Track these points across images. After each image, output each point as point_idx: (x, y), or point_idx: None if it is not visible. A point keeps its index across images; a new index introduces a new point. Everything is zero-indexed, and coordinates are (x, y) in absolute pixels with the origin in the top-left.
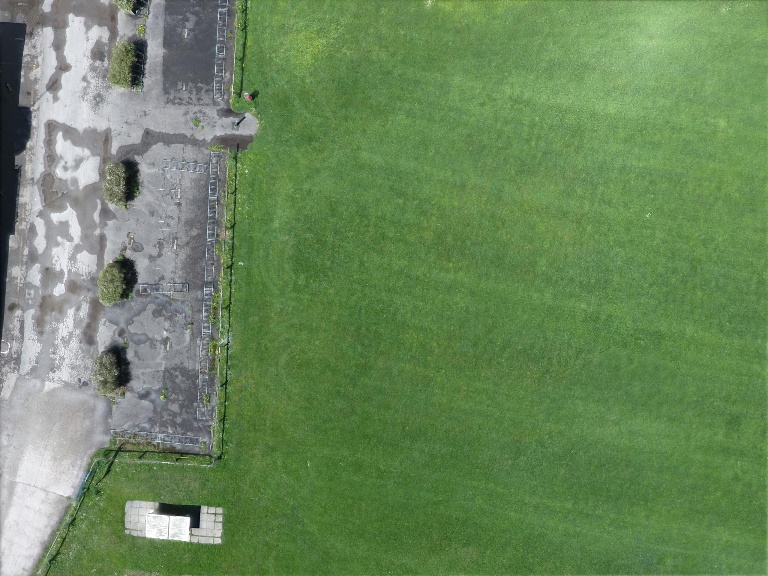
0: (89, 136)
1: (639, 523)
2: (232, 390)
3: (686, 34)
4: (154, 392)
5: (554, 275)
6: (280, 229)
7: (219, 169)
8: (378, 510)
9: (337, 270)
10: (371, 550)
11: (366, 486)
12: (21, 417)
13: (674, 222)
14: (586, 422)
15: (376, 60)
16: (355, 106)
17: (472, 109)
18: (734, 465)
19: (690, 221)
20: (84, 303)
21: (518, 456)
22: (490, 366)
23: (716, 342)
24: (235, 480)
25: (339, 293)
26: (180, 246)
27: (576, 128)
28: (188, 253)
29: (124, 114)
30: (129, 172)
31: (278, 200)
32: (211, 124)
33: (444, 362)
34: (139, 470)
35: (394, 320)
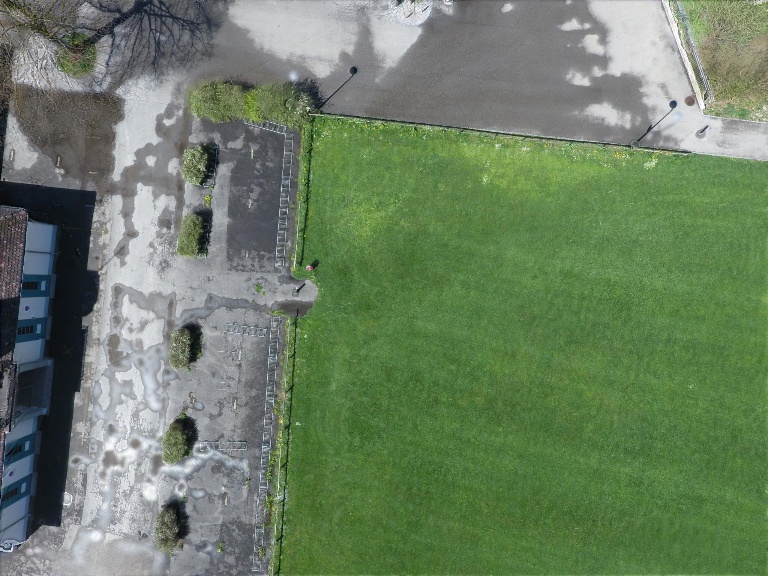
0: (154, 299)
1: None
2: (287, 544)
3: (729, 216)
4: (211, 545)
5: (600, 441)
6: (337, 392)
7: (279, 333)
8: None
9: (391, 432)
10: None
11: None
12: (82, 567)
13: (716, 393)
14: None
15: (432, 233)
16: (411, 277)
17: (524, 282)
18: None
19: (731, 393)
20: (145, 458)
21: None
22: (537, 527)
23: (755, 509)
24: None
25: (393, 454)
26: (240, 406)
27: (623, 303)
28: (247, 412)
29: (189, 279)
30: (193, 336)
31: (335, 364)
32: (272, 290)
33: (493, 522)
34: None
35: (445, 481)
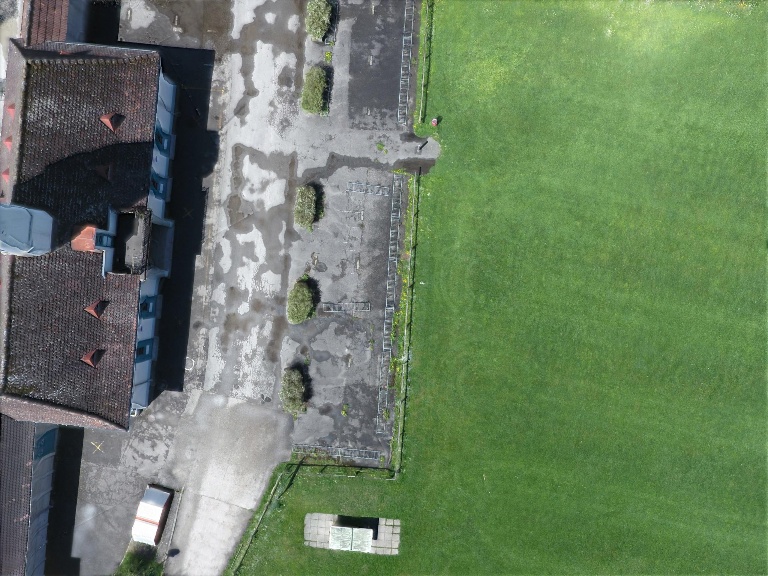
0: (275, 159)
1: None
2: (411, 406)
3: None
4: (335, 408)
5: (726, 295)
6: (461, 250)
7: (402, 192)
8: (552, 522)
9: (516, 290)
10: (544, 560)
11: (540, 498)
12: (204, 432)
13: None
14: (755, 436)
15: (556, 87)
16: (536, 131)
17: (649, 135)
18: None
19: None
20: (268, 321)
21: (688, 469)
22: (663, 382)
23: None
24: (413, 493)
25: (517, 312)
26: (362, 266)
27: (750, 154)
28: (370, 273)
29: (310, 138)
30: None
31: (459, 222)
32: (394, 148)
33: (618, 378)
34: (320, 483)
35: (570, 338)
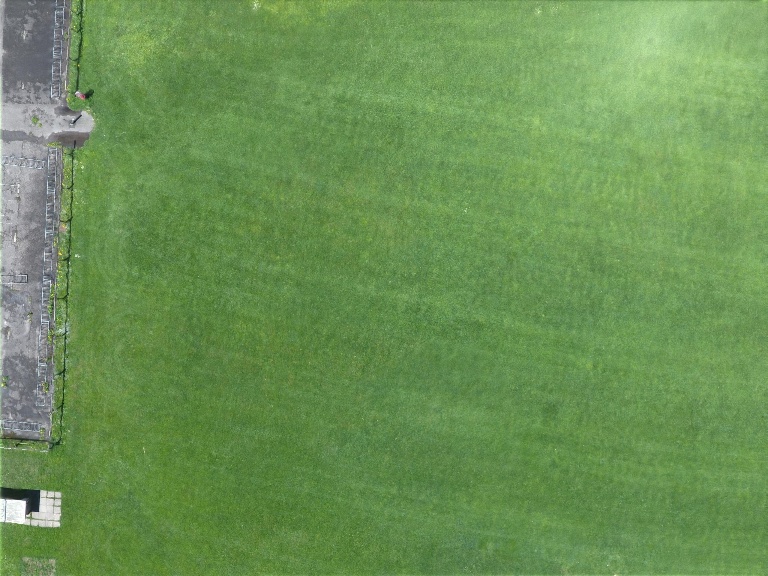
0: None
1: (461, 508)
2: (70, 378)
3: (499, 36)
4: None
5: (377, 268)
6: (114, 223)
7: (57, 165)
8: (211, 495)
9: (169, 262)
10: (204, 534)
11: (199, 472)
12: None
13: (490, 217)
14: (408, 410)
15: (205, 61)
16: (185, 105)
17: (297, 108)
18: (551, 452)
19: (506, 216)
20: None
21: (344, 443)
22: (316, 355)
23: (532, 333)
24: (73, 465)
25: (171, 285)
26: (20, 239)
27: (395, 126)
28: (27, 246)
29: None
30: None
31: (113, 195)
32: (49, 122)
33: (272, 351)
34: None
35: (224, 311)
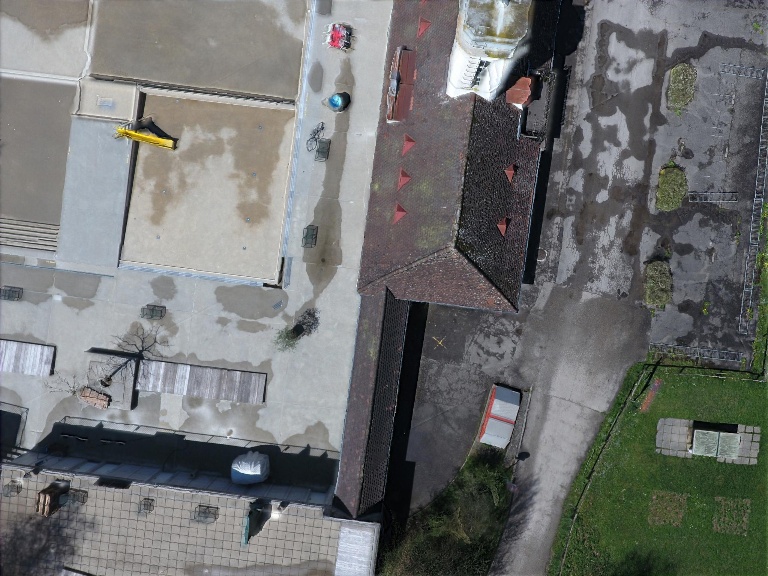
0: (644, 37)
1: None
2: None
3: None
4: (695, 305)
5: None
6: None
7: None
8: None
9: None
10: None
11: None
12: (555, 328)
13: None
14: None
15: None
16: None
17: None
18: None
19: None
20: (628, 211)
21: None
22: None
23: None
24: None
25: None
26: (731, 154)
27: None
28: (740, 161)
29: (682, 16)
30: None
31: None
32: None
33: None
34: (678, 386)
35: None
